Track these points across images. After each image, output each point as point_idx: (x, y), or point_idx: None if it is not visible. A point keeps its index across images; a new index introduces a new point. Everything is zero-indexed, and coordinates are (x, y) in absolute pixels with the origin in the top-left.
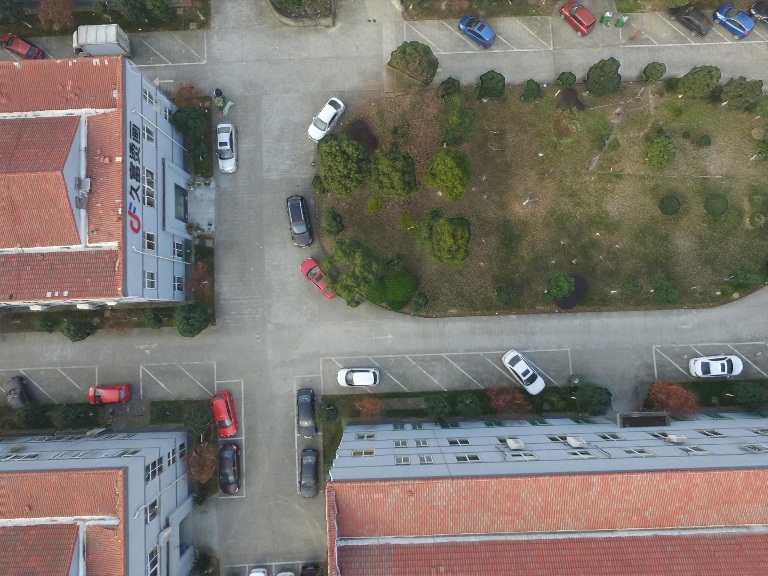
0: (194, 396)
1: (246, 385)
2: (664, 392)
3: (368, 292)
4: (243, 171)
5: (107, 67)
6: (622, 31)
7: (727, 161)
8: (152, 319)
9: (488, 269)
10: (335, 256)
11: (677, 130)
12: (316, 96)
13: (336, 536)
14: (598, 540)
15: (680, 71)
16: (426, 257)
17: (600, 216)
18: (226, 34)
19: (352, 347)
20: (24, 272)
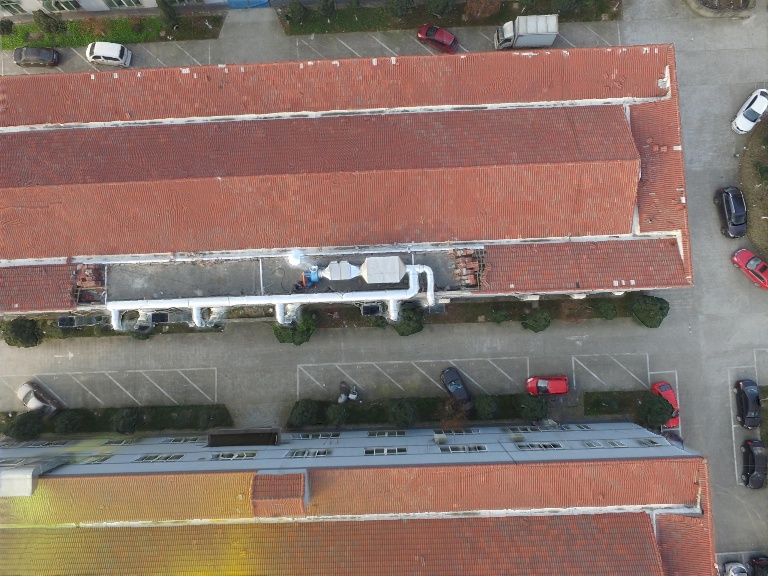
0: (628, 387)
1: (680, 376)
2: None
3: None
4: None
5: (656, 56)
6: None
7: None
8: (614, 310)
9: None
10: None
11: None
12: (734, 87)
13: None
14: None
15: None
16: None
17: None
18: (639, 25)
19: None
20: (582, 261)
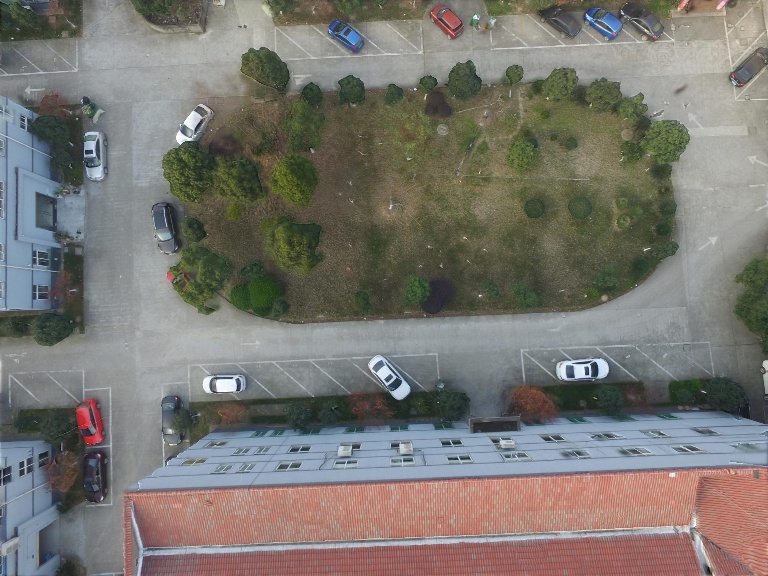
0: (62, 404)
1: (114, 393)
2: (523, 396)
3: (232, 299)
4: (113, 179)
5: None
6: (493, 34)
7: (596, 163)
8: (11, 328)
9: (355, 274)
10: (181, 264)
11: (546, 132)
12: (186, 103)
13: (142, 546)
14: (404, 548)
15: (550, 73)
16: None
17: (468, 220)
18: (97, 42)
19: (220, 354)
20: None
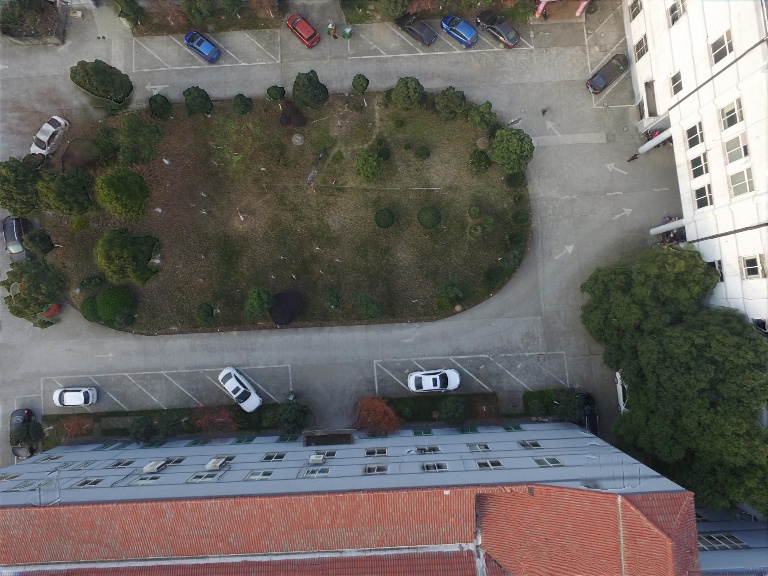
0: None
1: None
2: (366, 408)
3: (81, 311)
4: None
5: None
6: (350, 42)
7: (451, 172)
8: None
9: (208, 285)
10: None
11: (401, 141)
12: (44, 114)
13: None
14: (185, 567)
15: None
16: None
17: (321, 230)
18: None
19: (73, 366)
20: None
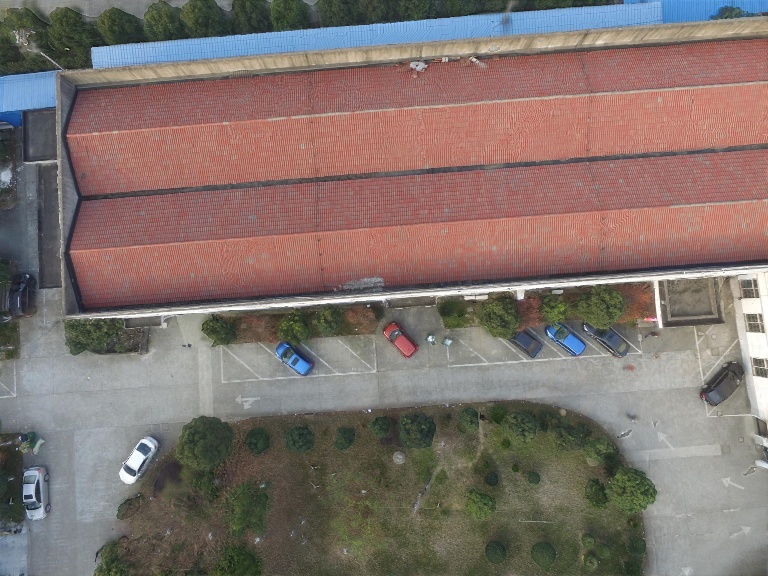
0: None
1: None
2: None
3: None
4: (56, 514)
5: None
6: (449, 349)
7: (561, 492)
8: None
9: None
10: None
11: (508, 459)
12: (130, 430)
13: None
14: None
15: (511, 391)
16: None
17: (427, 557)
18: (36, 364)
19: None
20: None
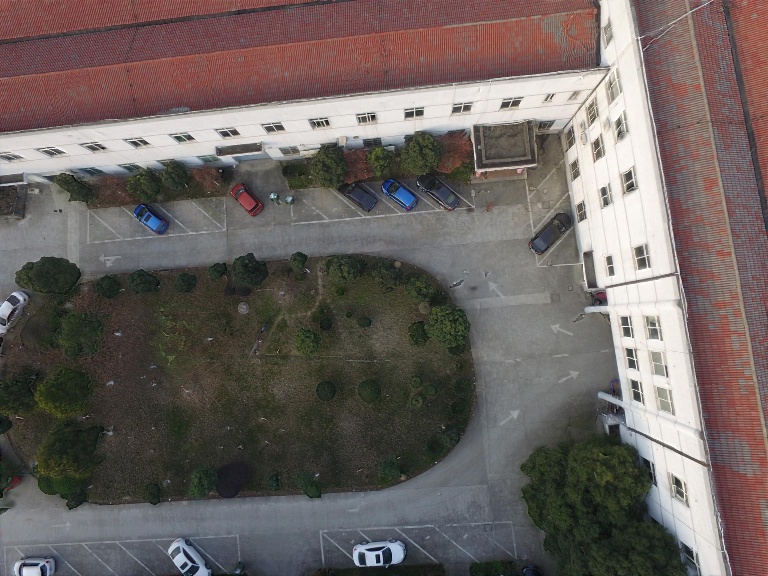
0: None
1: None
2: None
3: (38, 486)
4: None
5: None
6: (293, 208)
7: (393, 338)
8: None
9: (159, 456)
10: None
11: (344, 308)
12: (6, 287)
13: None
14: None
15: (350, 246)
16: (100, 445)
17: (267, 399)
18: None
19: (33, 535)
20: None
